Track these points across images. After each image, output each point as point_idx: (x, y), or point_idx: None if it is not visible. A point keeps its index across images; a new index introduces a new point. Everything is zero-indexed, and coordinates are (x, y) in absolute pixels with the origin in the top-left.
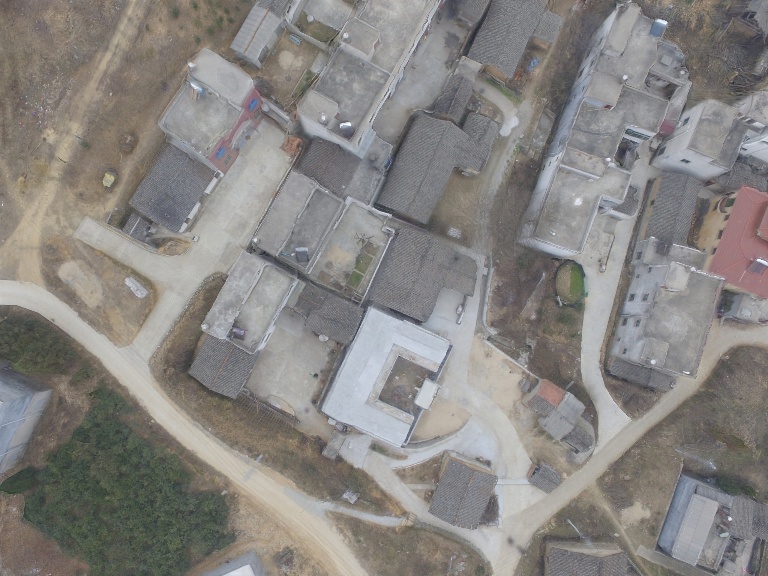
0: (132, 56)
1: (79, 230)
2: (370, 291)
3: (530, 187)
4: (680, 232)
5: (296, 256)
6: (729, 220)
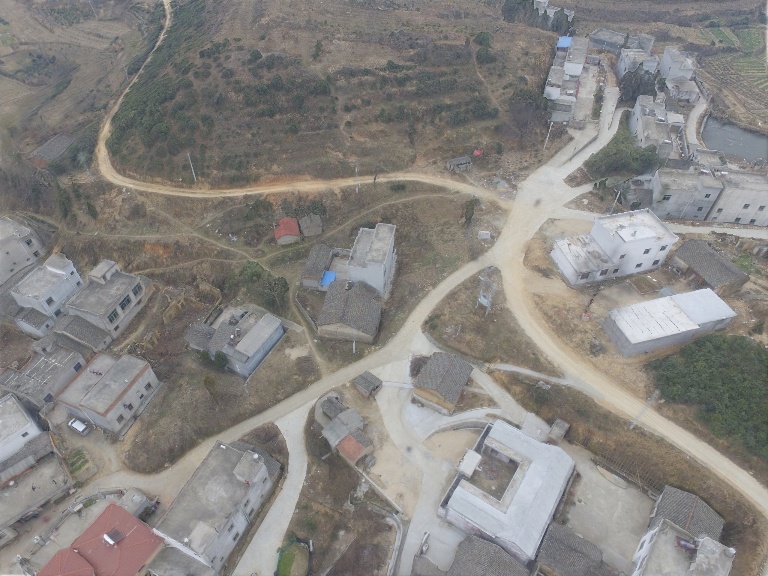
0: None
1: None
2: None
3: None
4: None
5: None
6: None
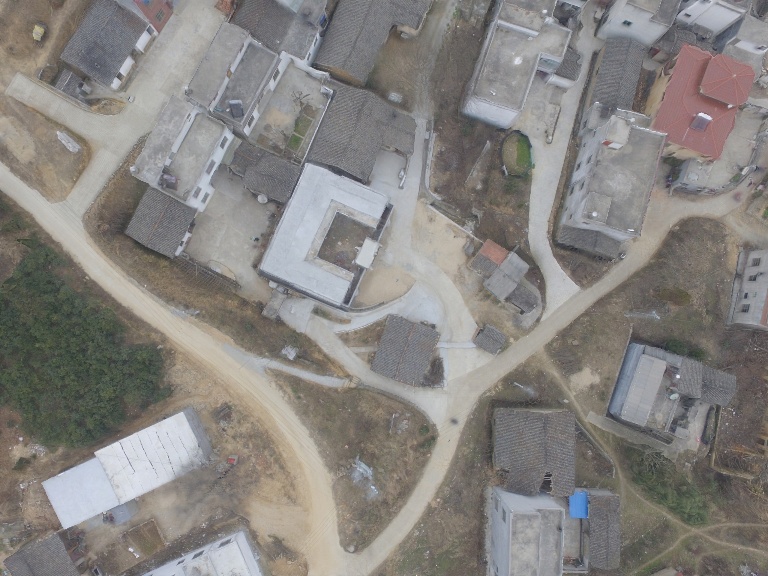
0: None
1: (11, 87)
2: (309, 153)
3: (473, 56)
4: (625, 97)
5: (231, 111)
6: (672, 79)
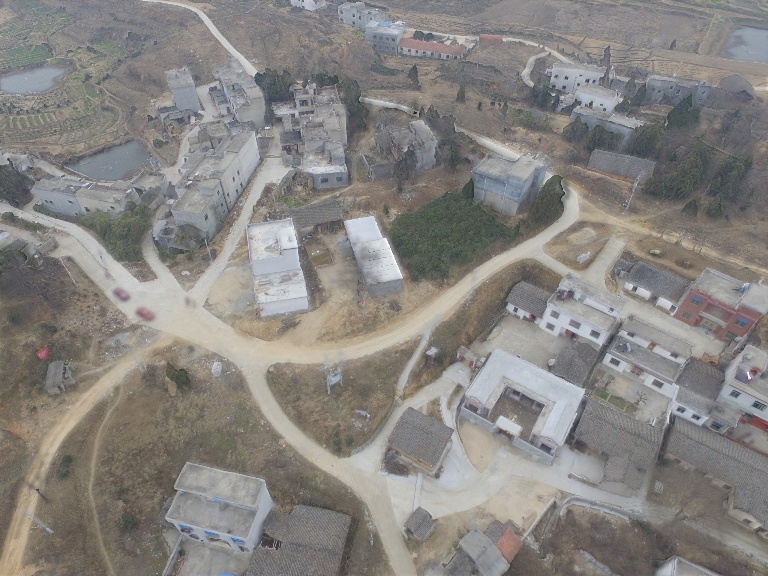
0: (747, 270)
1: (616, 240)
2: None
3: None
4: None
5: None
6: None
